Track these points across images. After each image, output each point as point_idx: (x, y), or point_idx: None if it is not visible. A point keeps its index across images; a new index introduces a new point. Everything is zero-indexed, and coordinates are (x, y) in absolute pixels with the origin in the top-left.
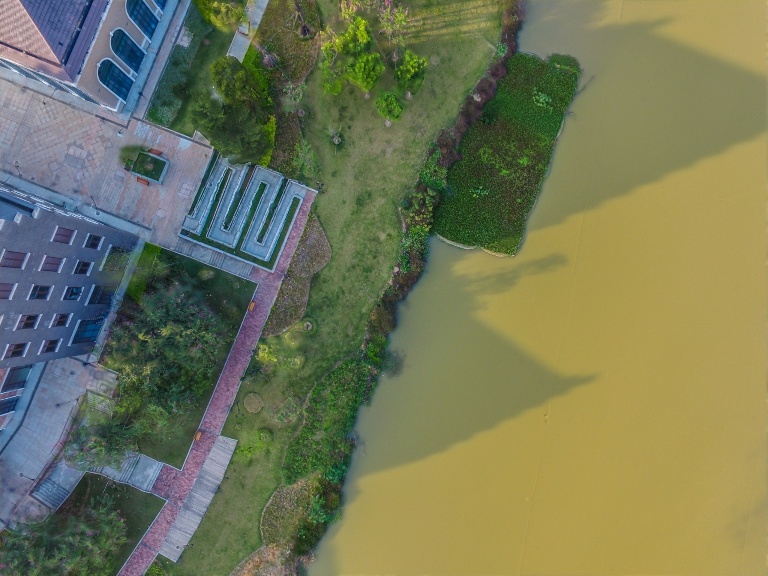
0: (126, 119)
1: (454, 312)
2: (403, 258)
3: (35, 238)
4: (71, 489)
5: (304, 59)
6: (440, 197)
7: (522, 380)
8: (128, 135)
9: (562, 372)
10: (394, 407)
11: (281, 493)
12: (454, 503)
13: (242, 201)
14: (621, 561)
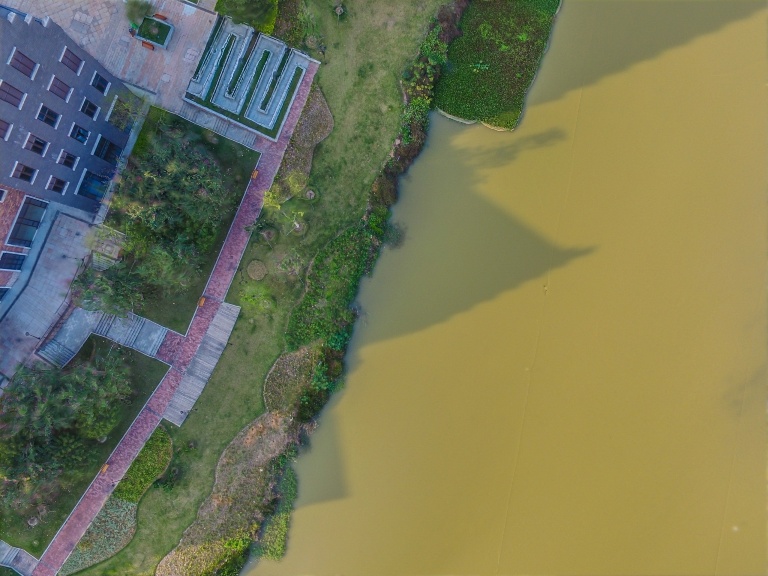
0: None
1: (455, 185)
2: (404, 129)
3: (44, 50)
4: (76, 350)
5: None
6: (441, 71)
7: (522, 252)
8: (133, 1)
9: (561, 244)
10: (395, 278)
11: (284, 360)
12: (455, 372)
13: (246, 68)
14: (620, 429)
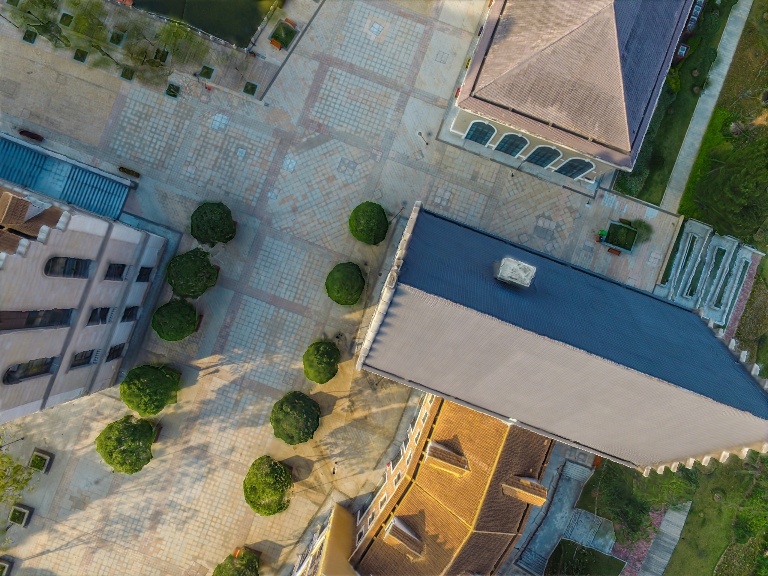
0: (593, 189)
1: None
2: None
3: None
4: (547, 556)
5: (765, 125)
6: None
7: None
8: (595, 205)
9: None
10: None
11: (731, 551)
12: None
13: None
14: None
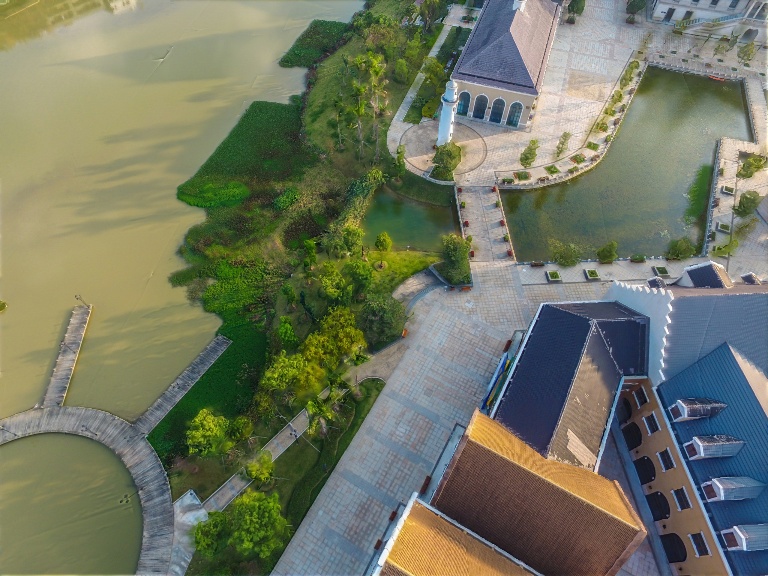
0: None
1: (340, 8)
2: (362, 15)
3: None
4: None
5: None
6: None
7: None
8: None
9: None
10: None
11: None
12: None
13: None
14: None
